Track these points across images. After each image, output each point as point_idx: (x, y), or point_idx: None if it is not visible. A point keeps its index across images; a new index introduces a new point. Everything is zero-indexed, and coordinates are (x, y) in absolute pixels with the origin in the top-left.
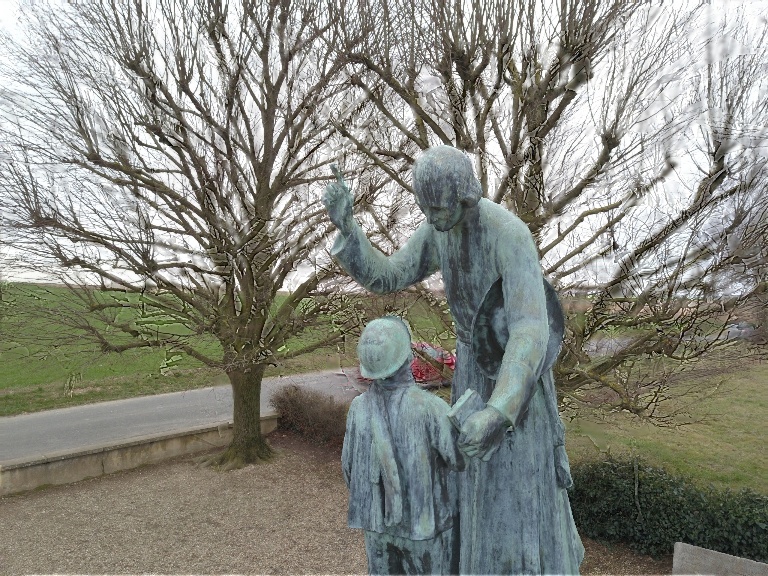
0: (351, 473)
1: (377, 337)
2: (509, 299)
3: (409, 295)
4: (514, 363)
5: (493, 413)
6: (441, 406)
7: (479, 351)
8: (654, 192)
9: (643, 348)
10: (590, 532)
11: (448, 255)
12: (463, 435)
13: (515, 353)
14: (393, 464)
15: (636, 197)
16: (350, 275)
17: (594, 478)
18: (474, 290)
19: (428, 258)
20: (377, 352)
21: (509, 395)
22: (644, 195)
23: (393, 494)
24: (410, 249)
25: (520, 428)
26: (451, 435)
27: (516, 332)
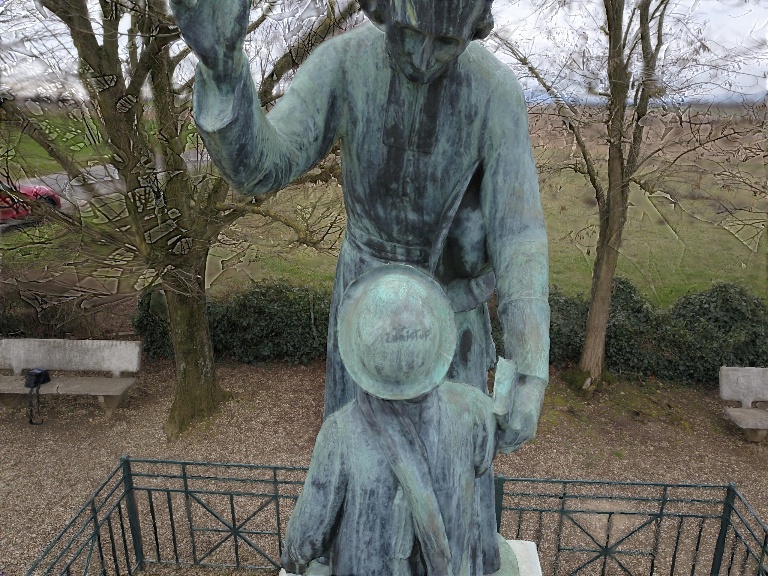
0: (344, 554)
1: (421, 323)
2: (502, 199)
3: (6, 124)
4: (536, 301)
5: (541, 387)
6: (484, 401)
7: (434, 276)
8: (328, 1)
9: (306, 177)
10: (246, 358)
11: (386, 122)
12: (516, 435)
13: (532, 285)
14: (441, 523)
15: (314, 6)
16: (227, 169)
17: (245, 307)
18: (430, 182)
19: (335, 124)
20: (423, 351)
21: (547, 353)
22: (325, 4)
23: (446, 568)
24: (307, 107)
25: (463, 364)
26: (494, 438)
27: (523, 251)
